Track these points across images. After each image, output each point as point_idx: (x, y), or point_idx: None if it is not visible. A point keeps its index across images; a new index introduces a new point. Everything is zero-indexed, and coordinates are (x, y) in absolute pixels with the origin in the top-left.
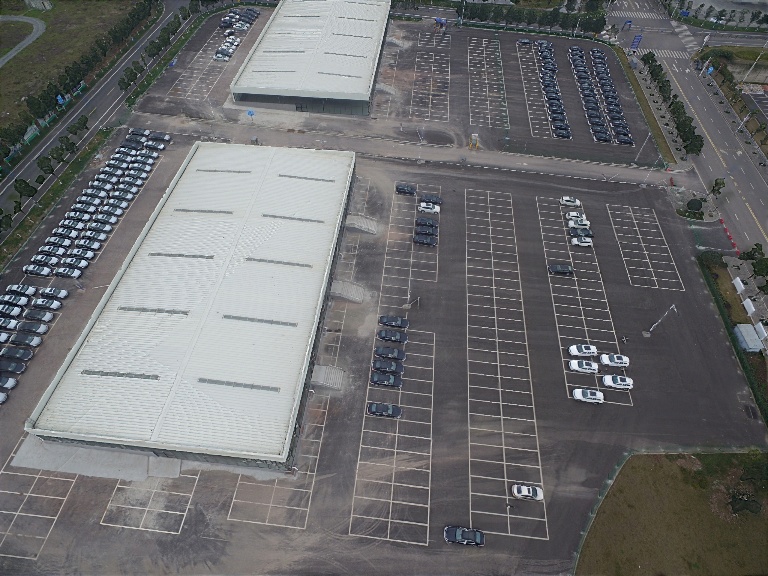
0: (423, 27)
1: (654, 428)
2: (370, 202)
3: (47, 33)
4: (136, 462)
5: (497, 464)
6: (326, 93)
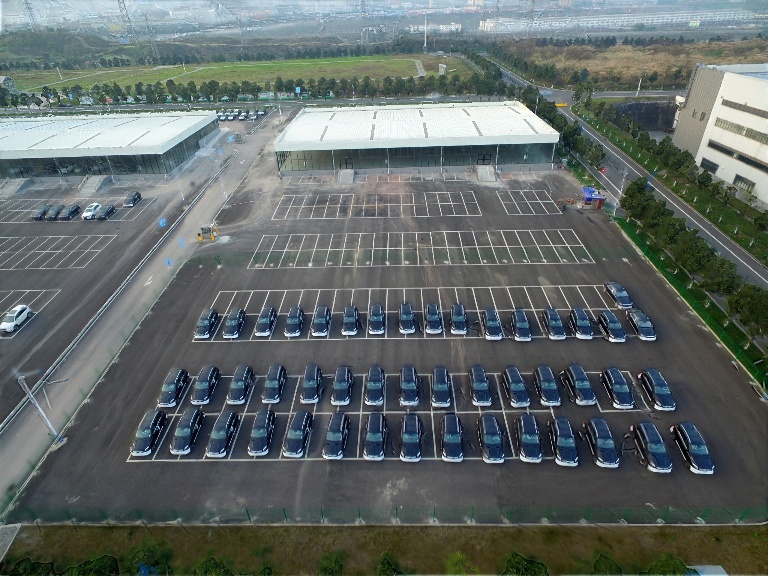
0: (569, 191)
1: None
2: (130, 188)
3: None
4: None
5: None
6: None
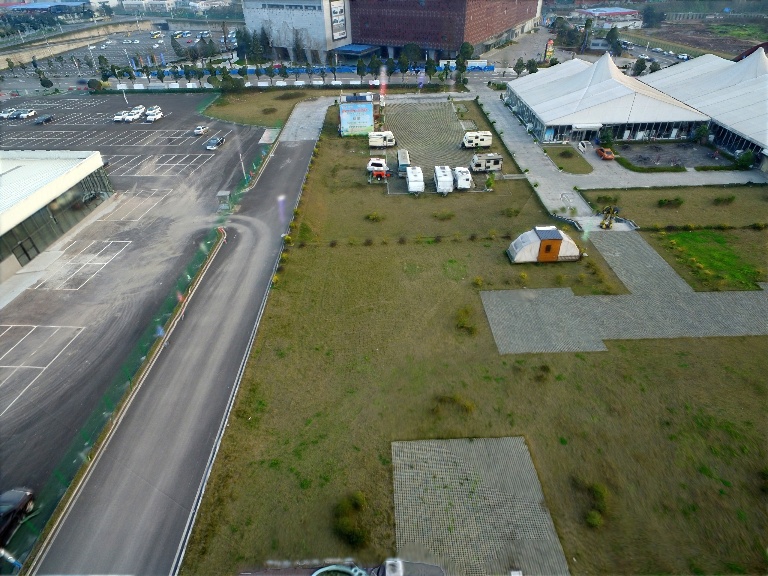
0: None
1: None
2: None
3: None
4: (13, 282)
5: (177, 139)
6: None
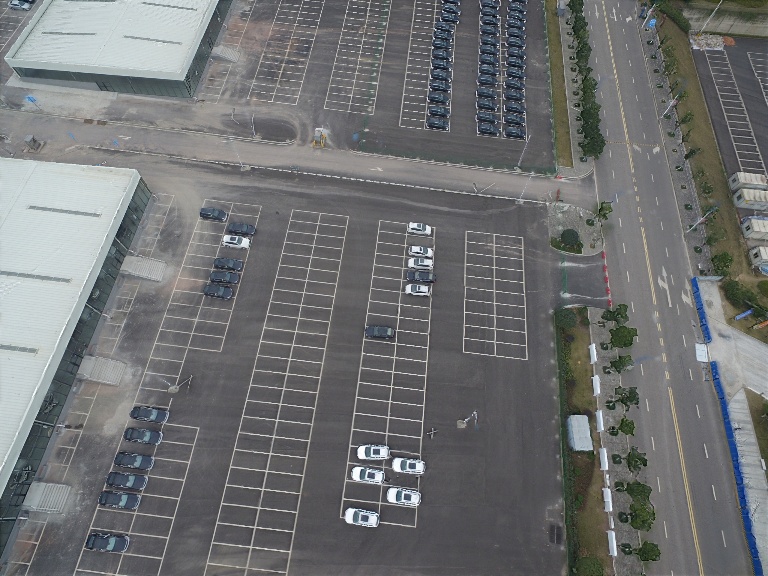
0: None
1: (432, 559)
2: (165, 232)
3: None
4: None
5: None
6: (127, 70)
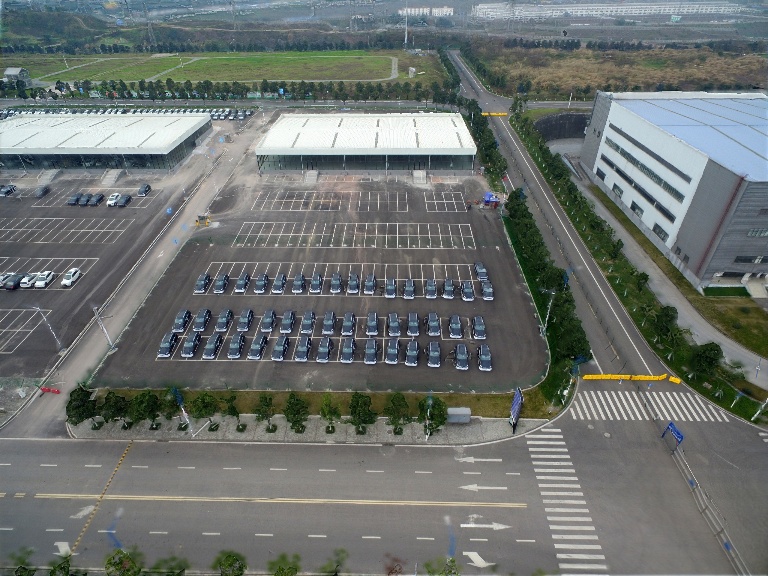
0: (479, 194)
1: None
2: (141, 180)
3: (374, 81)
4: None
5: None
6: None
